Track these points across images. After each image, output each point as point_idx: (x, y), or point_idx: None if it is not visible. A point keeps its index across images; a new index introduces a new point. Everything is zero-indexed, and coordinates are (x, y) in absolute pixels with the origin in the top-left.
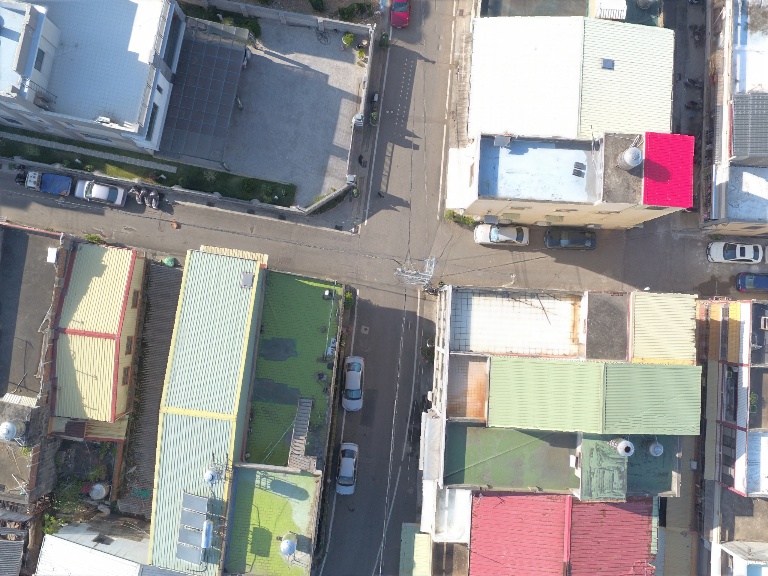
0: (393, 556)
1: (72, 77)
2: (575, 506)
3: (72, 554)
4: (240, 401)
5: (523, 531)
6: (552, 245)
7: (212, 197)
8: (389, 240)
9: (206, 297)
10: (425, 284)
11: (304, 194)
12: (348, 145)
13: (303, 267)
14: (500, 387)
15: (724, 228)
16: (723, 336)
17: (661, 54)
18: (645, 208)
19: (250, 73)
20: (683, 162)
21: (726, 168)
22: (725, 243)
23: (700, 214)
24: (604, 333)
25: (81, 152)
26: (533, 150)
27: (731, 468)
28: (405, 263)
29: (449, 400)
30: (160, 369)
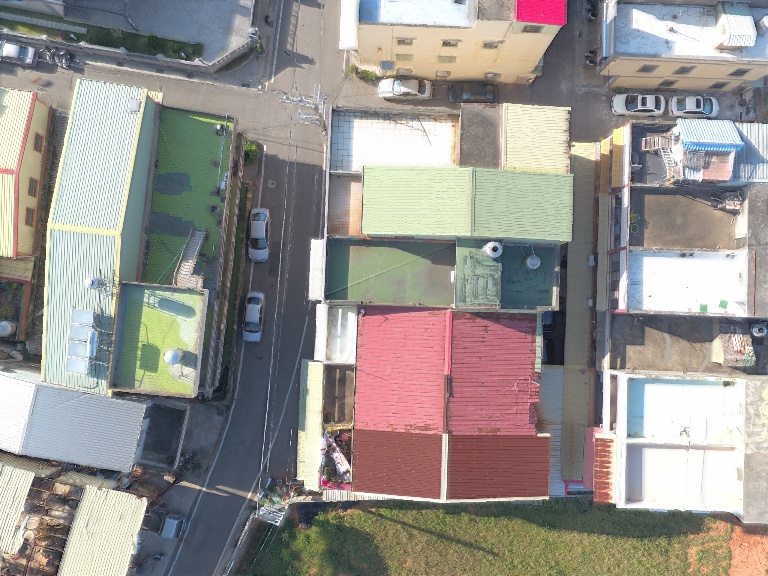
0: None
1: None
2: (456, 320)
3: None
4: (128, 222)
5: (406, 347)
6: (455, 98)
7: (120, 54)
8: None
9: (94, 122)
10: (319, 122)
11: (212, 53)
12: None
13: None
14: (373, 195)
15: (621, 73)
16: (610, 165)
17: None
18: (523, 30)
19: None
20: None
21: (614, 3)
22: (627, 94)
23: None
24: (477, 144)
25: None
26: None
27: (616, 291)
28: (291, 91)
29: (332, 220)
30: None
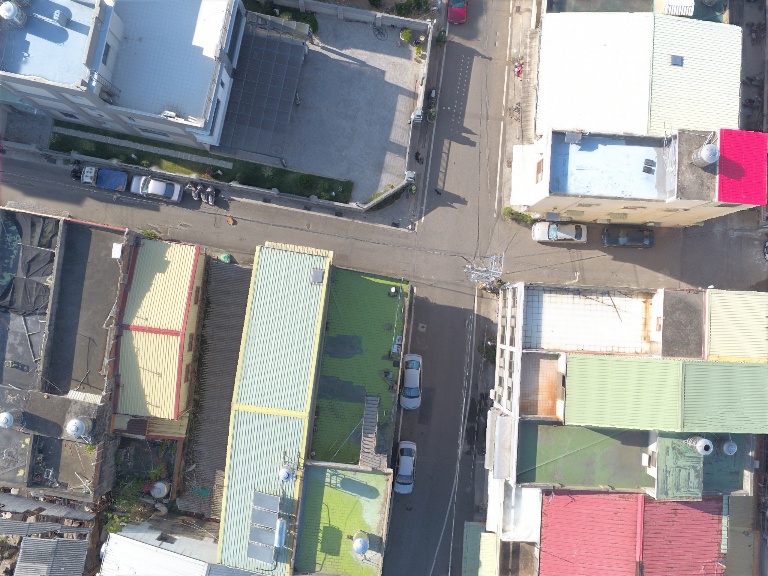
0: None
1: (136, 71)
2: (647, 505)
3: (137, 553)
4: (310, 398)
5: (594, 530)
6: (610, 243)
7: (270, 193)
8: (446, 237)
9: (276, 293)
10: (490, 281)
11: (361, 191)
12: (405, 141)
13: (360, 264)
14: (577, 385)
15: None
16: None
17: (730, 51)
18: (717, 205)
19: (306, 69)
20: (757, 159)
21: None
22: None
23: (761, 212)
24: (680, 331)
25: (136, 147)
26: (603, 147)
27: None
28: (474, 260)
29: (520, 398)
30: (220, 366)
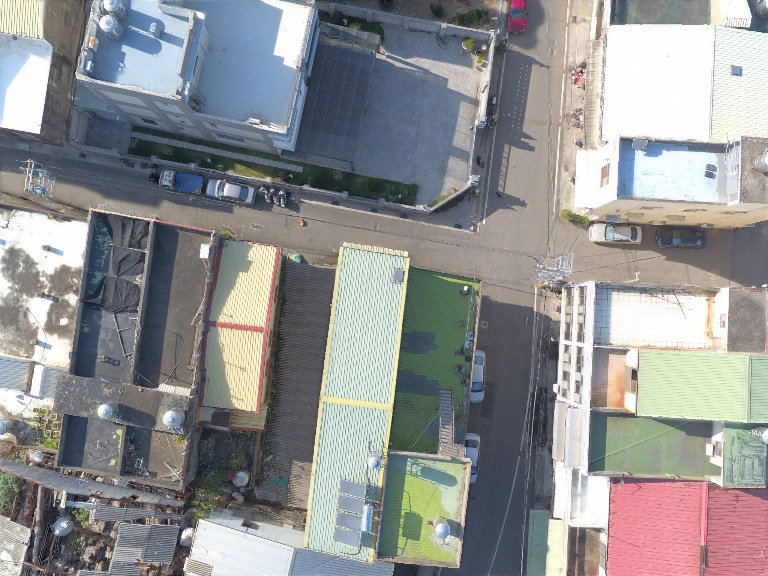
0: (513, 542)
1: (220, 80)
2: (711, 492)
3: (225, 538)
4: None
5: (661, 516)
6: (664, 244)
7: (339, 196)
8: (507, 238)
9: (360, 292)
10: (555, 280)
11: (425, 193)
12: (467, 146)
13: (424, 264)
14: (648, 378)
15: None
16: None
17: None
18: None
19: (373, 76)
20: None
21: None
22: None
23: None
24: (744, 327)
25: (211, 152)
26: (667, 152)
27: None
28: (545, 260)
29: None
30: (295, 361)
